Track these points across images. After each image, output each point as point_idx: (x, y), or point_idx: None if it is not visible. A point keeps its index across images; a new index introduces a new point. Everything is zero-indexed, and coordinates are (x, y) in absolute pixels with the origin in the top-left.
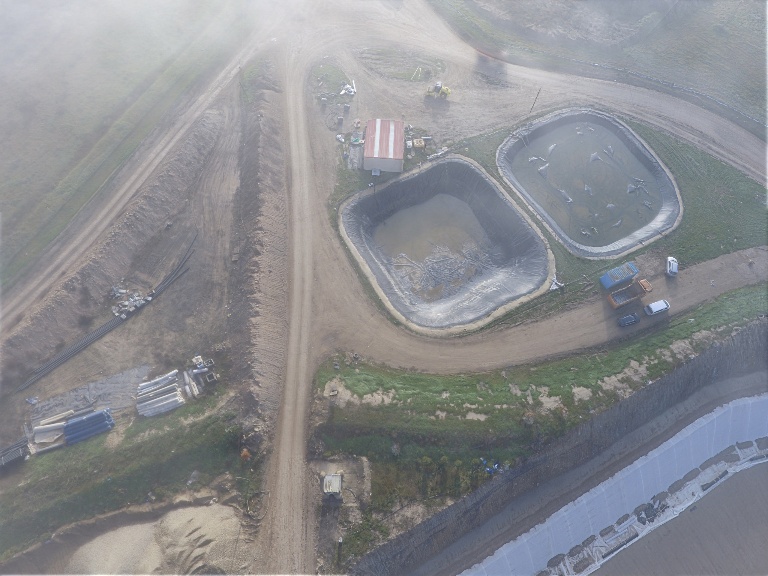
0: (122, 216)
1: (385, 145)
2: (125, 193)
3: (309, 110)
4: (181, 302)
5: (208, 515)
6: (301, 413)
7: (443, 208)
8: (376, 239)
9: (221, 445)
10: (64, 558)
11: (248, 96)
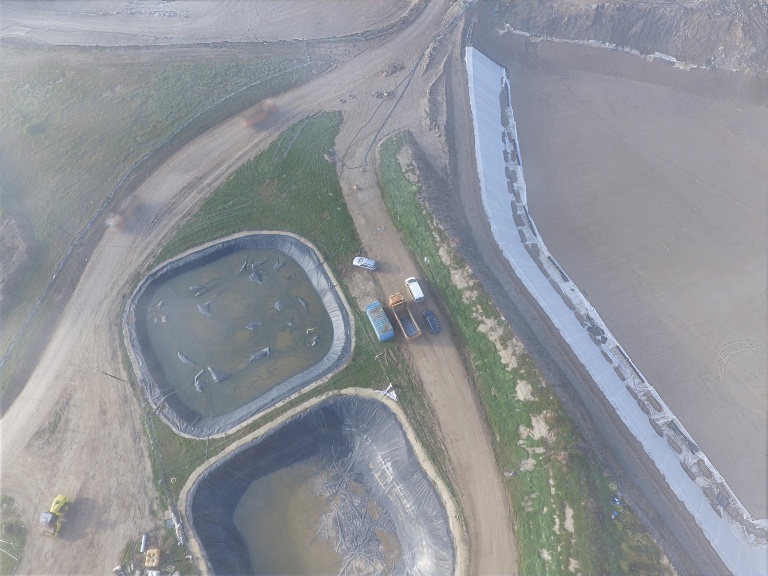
0: None
1: None
2: None
3: None
4: None
5: None
6: None
7: (258, 518)
8: None
9: None
10: None
11: None
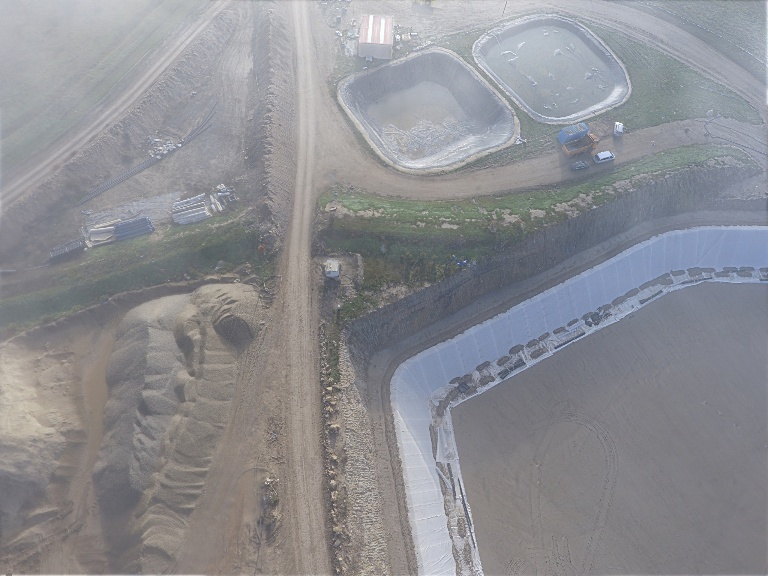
0: (155, 84)
1: (377, 34)
2: (156, 70)
3: (312, 12)
4: (206, 148)
5: (233, 288)
6: (307, 225)
7: (427, 92)
8: (369, 114)
9: (242, 242)
10: (118, 317)
11: (259, 1)
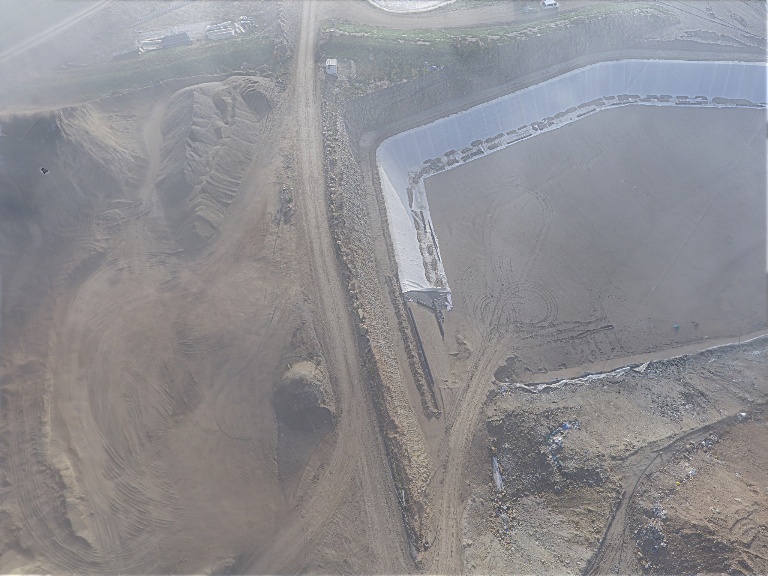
0: None
1: None
2: None
3: None
4: None
5: (255, 77)
6: (311, 43)
7: None
8: None
9: (261, 50)
10: (168, 96)
11: None
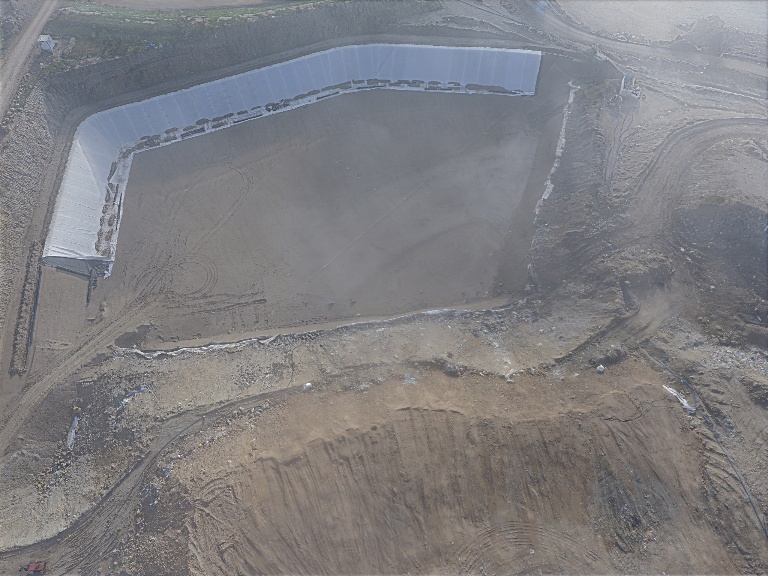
0: None
1: None
2: None
3: None
4: None
5: None
6: (44, 21)
7: None
8: None
9: None
10: None
11: None
